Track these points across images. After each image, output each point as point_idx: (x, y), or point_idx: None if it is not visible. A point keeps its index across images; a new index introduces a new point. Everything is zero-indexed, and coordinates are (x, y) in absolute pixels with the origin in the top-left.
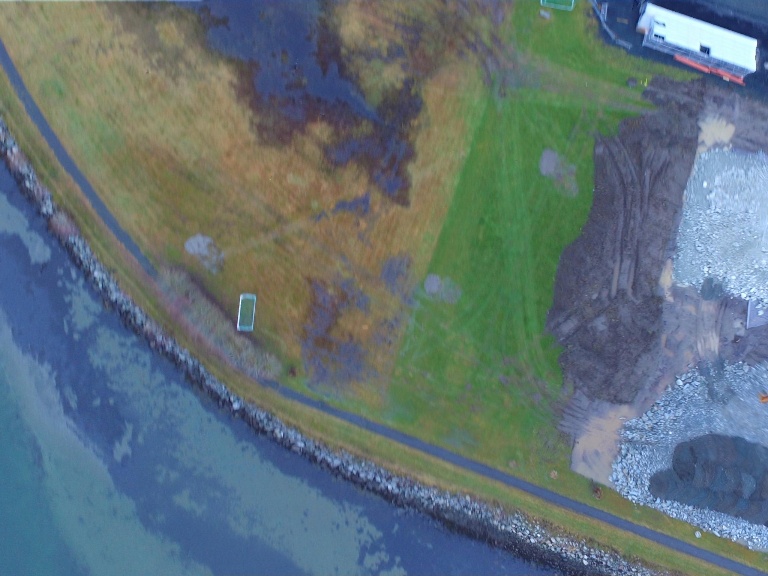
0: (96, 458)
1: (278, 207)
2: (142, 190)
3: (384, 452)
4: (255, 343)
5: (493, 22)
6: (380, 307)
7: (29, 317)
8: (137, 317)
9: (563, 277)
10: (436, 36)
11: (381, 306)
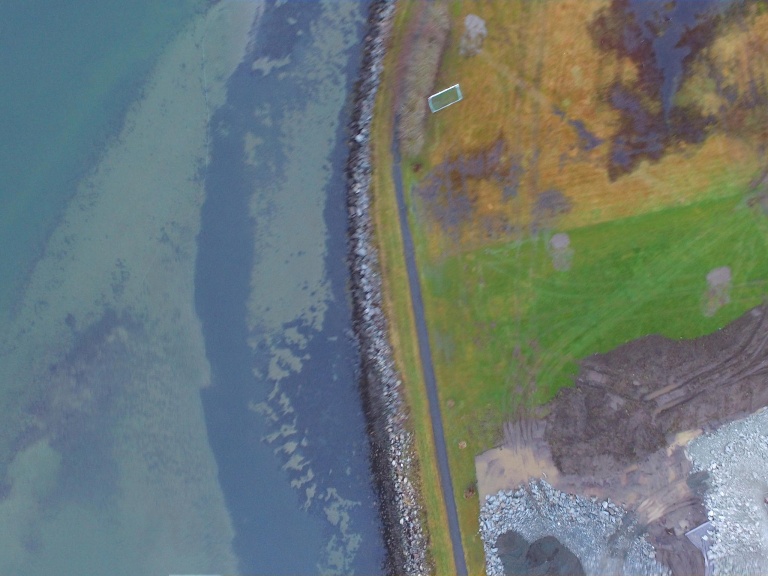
0: (244, 48)
1: (546, 73)
2: None
3: (396, 286)
4: (425, 120)
5: None
6: (515, 208)
7: None
8: (385, 11)
9: (634, 347)
10: (764, 119)
11: (516, 209)
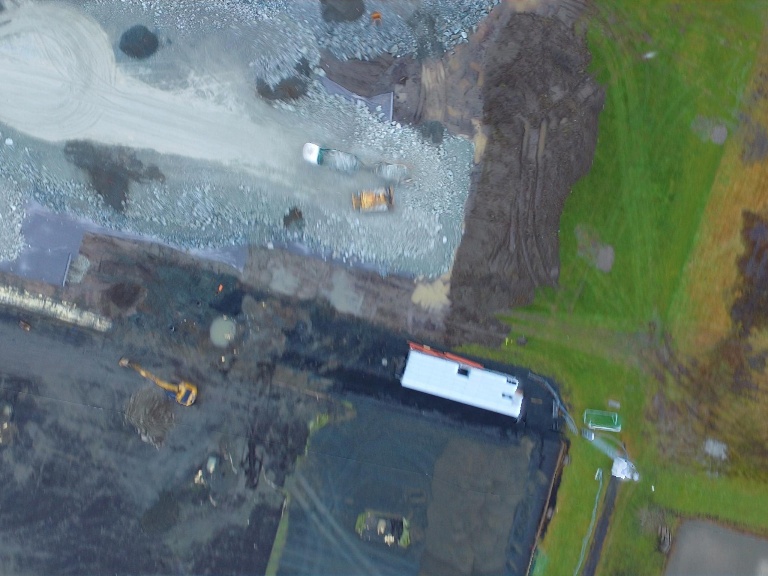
0: None
1: None
2: None
3: None
4: None
5: (664, 395)
6: None
7: None
8: None
9: (592, 142)
10: (719, 379)
11: None
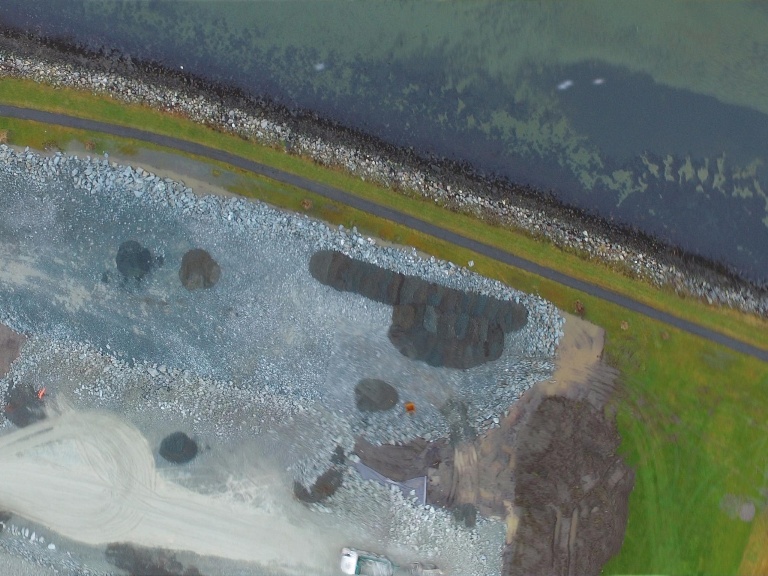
0: None
1: None
2: None
3: None
4: None
5: None
6: None
7: None
8: None
9: (623, 525)
10: None
11: None
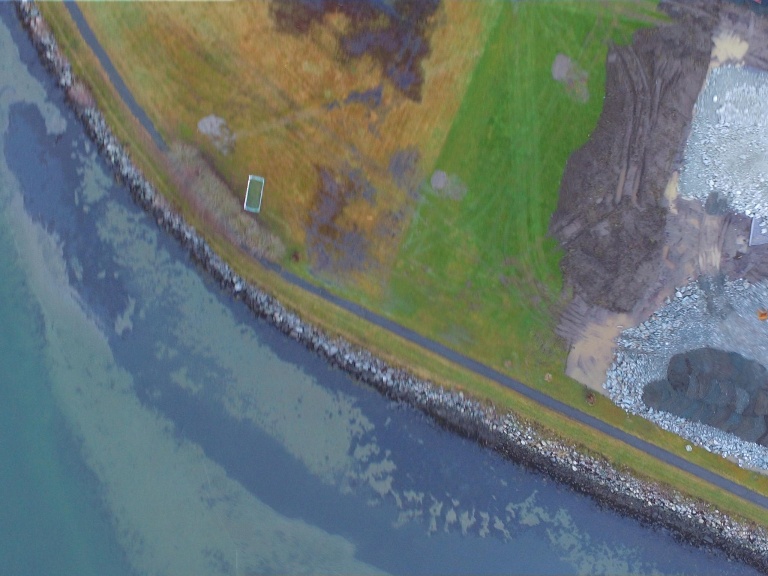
0: (97, 330)
1: (292, 93)
2: (160, 67)
3: (381, 343)
4: (261, 224)
5: None
6: (386, 199)
7: (41, 186)
8: (147, 193)
9: (569, 181)
10: None
11: (387, 198)
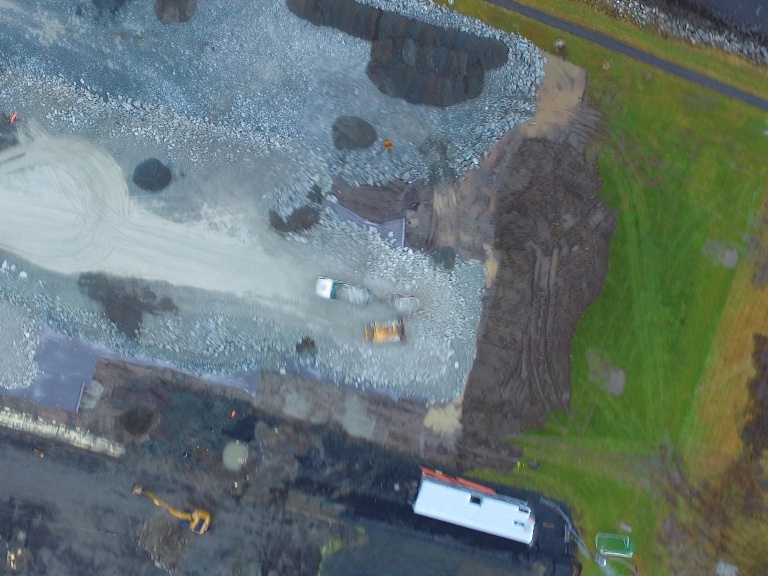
0: None
1: None
2: None
3: None
4: None
5: (675, 518)
6: None
7: None
8: None
9: (604, 267)
10: (730, 502)
11: None
